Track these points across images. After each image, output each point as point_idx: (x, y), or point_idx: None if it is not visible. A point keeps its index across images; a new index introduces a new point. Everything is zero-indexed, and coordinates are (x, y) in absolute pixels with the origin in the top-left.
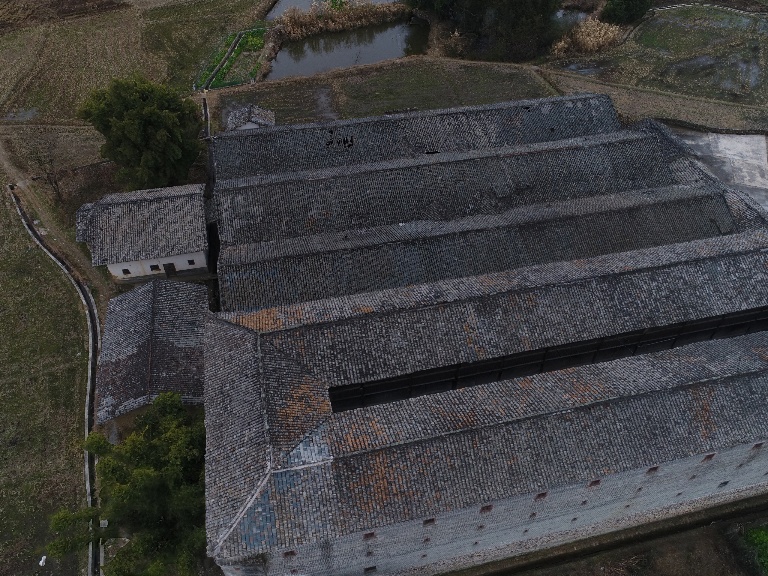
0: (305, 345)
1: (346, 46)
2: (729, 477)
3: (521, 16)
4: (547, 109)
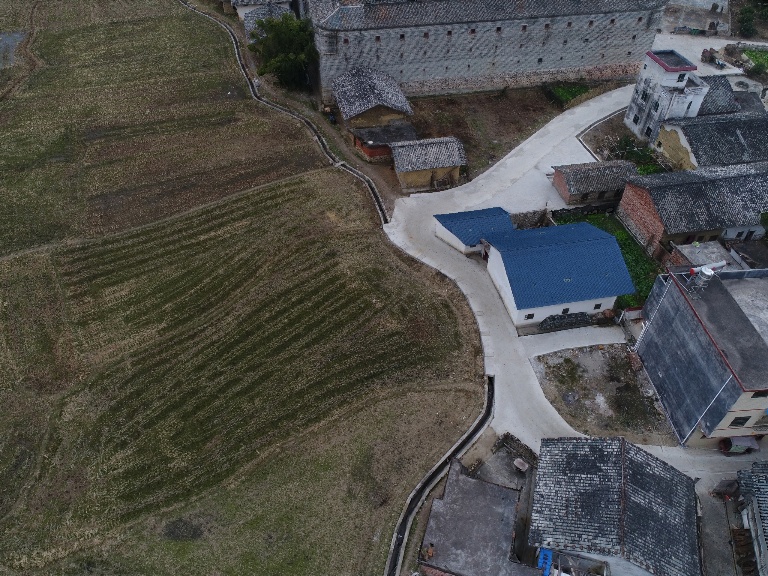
0: None
1: None
2: (541, 54)
3: None
4: None
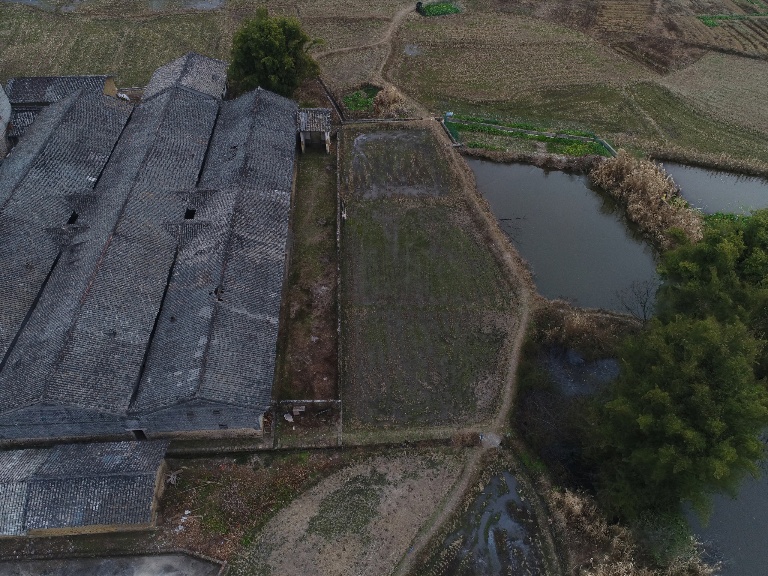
0: None
1: (653, 255)
2: None
3: (606, 397)
4: (206, 313)
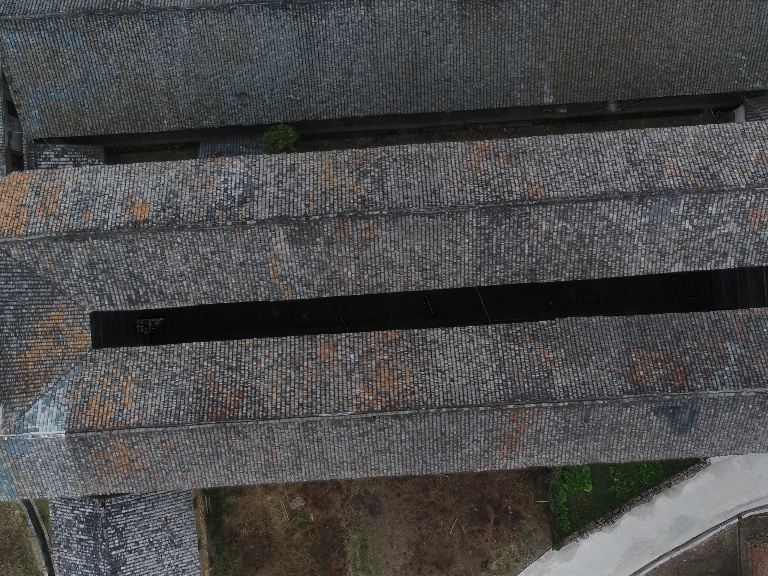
0: (54, 260)
1: None
2: None
3: None
4: None
